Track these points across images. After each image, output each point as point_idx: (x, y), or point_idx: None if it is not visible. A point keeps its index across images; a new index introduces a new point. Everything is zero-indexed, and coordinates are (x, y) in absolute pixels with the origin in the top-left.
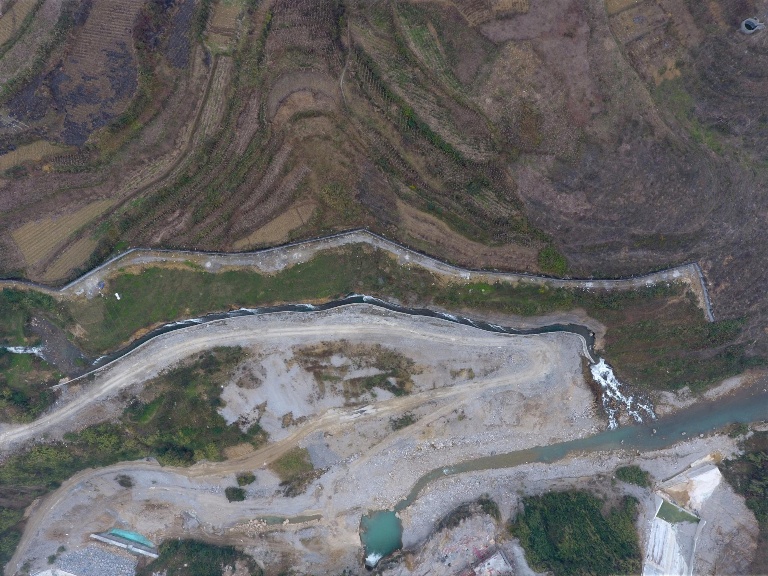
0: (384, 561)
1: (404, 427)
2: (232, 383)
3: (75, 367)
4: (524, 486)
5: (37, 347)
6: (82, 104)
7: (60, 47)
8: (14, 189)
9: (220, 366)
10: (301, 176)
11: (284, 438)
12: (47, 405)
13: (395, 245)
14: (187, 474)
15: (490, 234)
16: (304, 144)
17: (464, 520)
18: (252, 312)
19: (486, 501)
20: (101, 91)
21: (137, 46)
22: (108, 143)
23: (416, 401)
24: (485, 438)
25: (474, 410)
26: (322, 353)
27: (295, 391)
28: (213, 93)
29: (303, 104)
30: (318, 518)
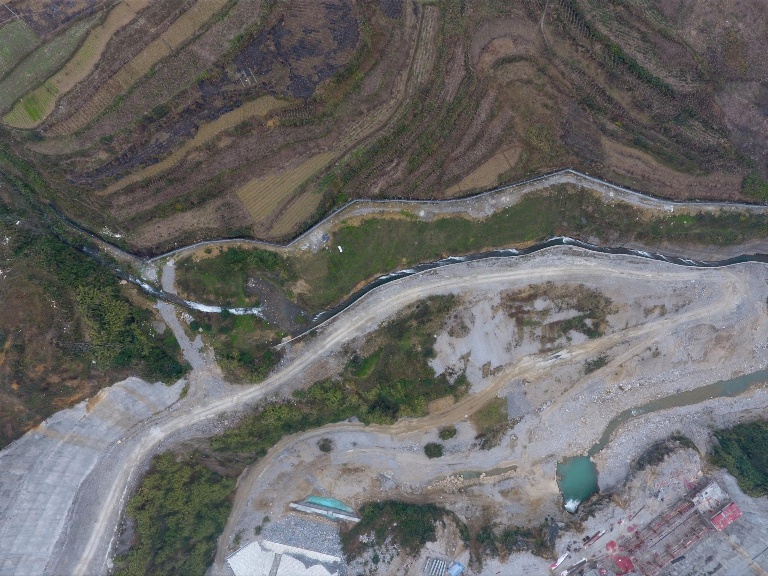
0: (585, 505)
1: (596, 370)
2: (444, 332)
3: (296, 325)
4: (713, 420)
5: (258, 307)
6: (305, 57)
7: (281, 2)
8: (239, 146)
9: (431, 316)
10: (506, 120)
11: (483, 389)
12: (272, 364)
13: (599, 183)
14: (389, 432)
15: (697, 164)
16: (507, 89)
17: (668, 455)
18: (460, 260)
19: (680, 437)
20: (323, 43)
21: None
22: (332, 94)
23: (609, 342)
24: (670, 376)
25: (668, 346)
26: (527, 297)
27: (496, 339)
28: (423, 42)
29: (504, 50)
30: (514, 469)
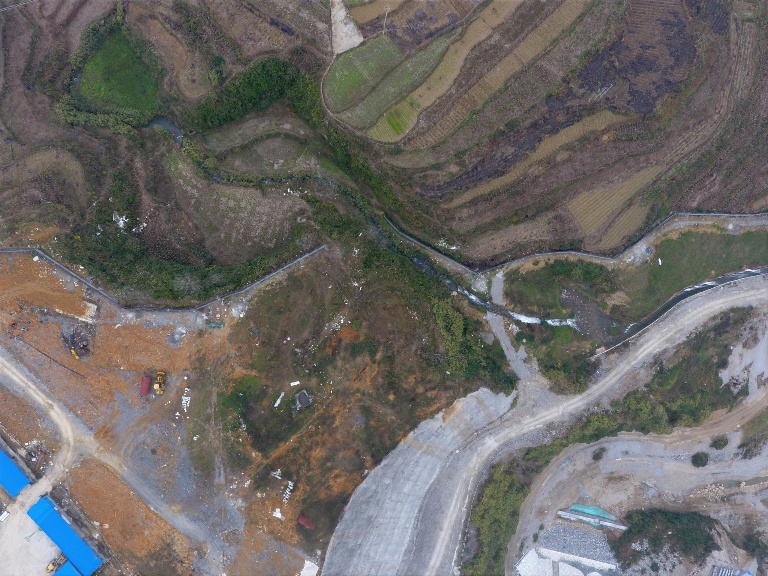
0: None
1: None
2: (740, 344)
3: (609, 336)
4: None
5: (573, 318)
6: (643, 73)
7: (621, 18)
8: (575, 160)
9: None
10: None
11: (754, 399)
12: (589, 375)
13: None
14: (663, 442)
15: None
16: None
17: None
18: (756, 272)
19: None
20: (660, 59)
21: (691, 14)
22: (666, 110)
23: None
24: None
25: None
26: None
27: None
28: (741, 58)
29: None
30: None
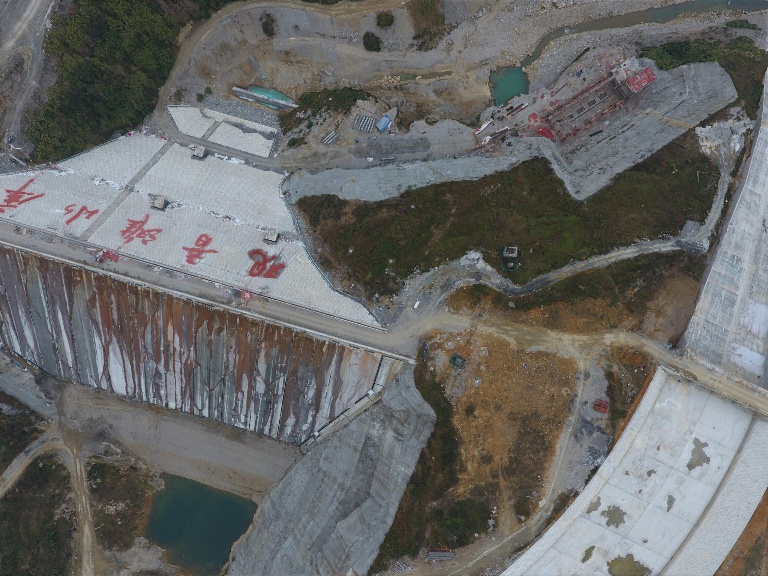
0: None
1: None
2: None
3: None
4: (642, 39)
5: None
6: None
7: None
8: None
9: None
10: None
11: None
12: None
13: None
14: (329, 14)
15: None
16: None
17: (594, 48)
18: None
19: None
20: None
21: None
22: None
23: None
24: None
25: None
26: None
27: None
28: None
29: None
30: (449, 74)
